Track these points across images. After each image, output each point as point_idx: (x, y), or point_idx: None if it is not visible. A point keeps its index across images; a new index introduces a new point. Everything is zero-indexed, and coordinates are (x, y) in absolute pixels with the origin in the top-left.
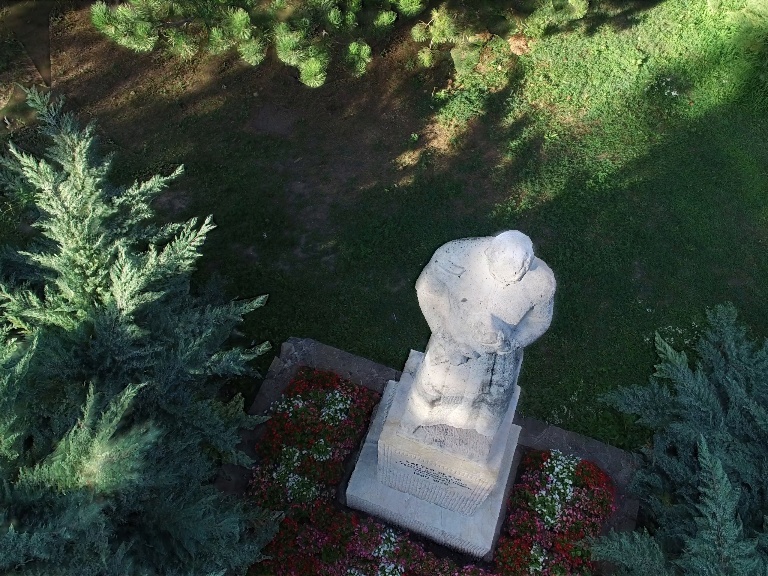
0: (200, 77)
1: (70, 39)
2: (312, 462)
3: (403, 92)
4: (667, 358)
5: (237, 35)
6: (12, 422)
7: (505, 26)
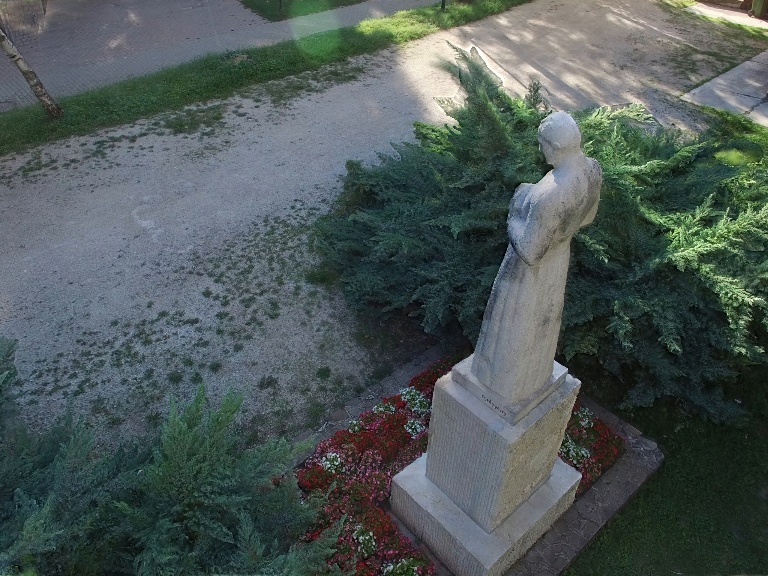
0: None
1: None
2: None
3: None
4: None
5: None
6: None
7: None
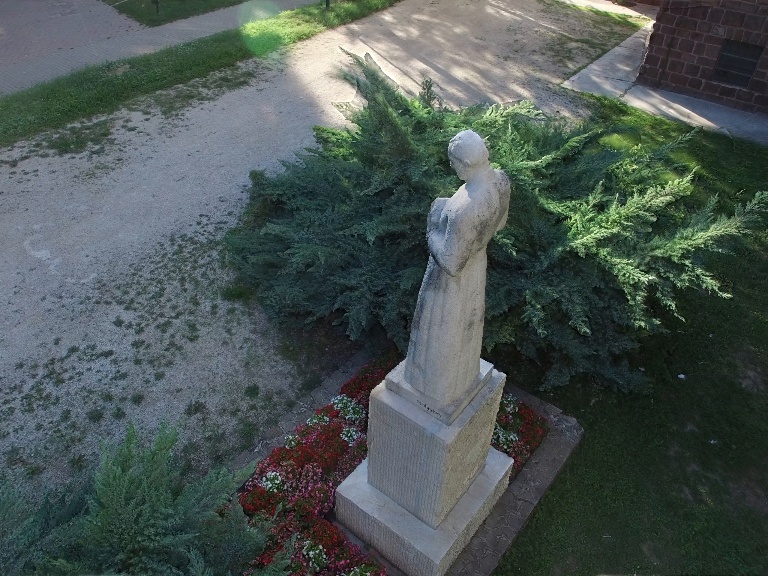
0: None
1: None
2: None
3: None
4: None
5: None
6: None
7: None
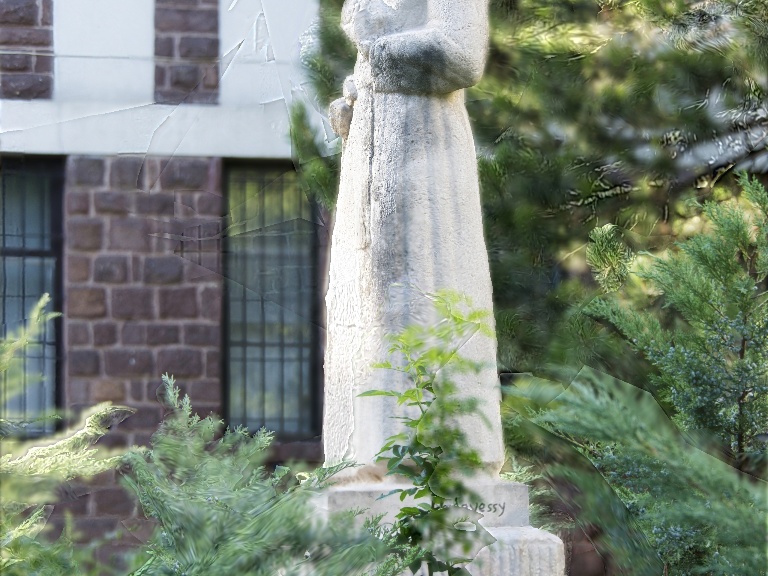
0: None
1: None
2: None
3: None
4: None
5: None
6: None
7: None
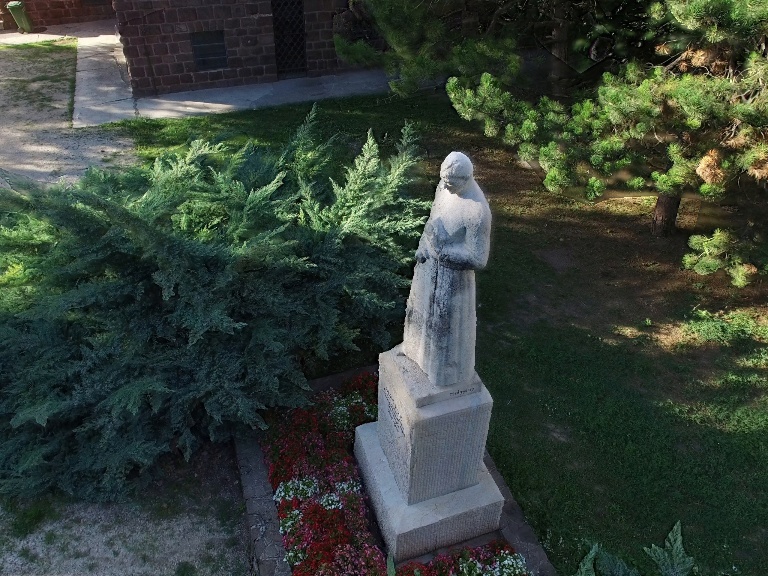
0: (537, 214)
1: (486, 162)
2: (361, 410)
3: (672, 296)
4: (671, 550)
5: (521, 135)
6: (250, 223)
7: (764, 261)
